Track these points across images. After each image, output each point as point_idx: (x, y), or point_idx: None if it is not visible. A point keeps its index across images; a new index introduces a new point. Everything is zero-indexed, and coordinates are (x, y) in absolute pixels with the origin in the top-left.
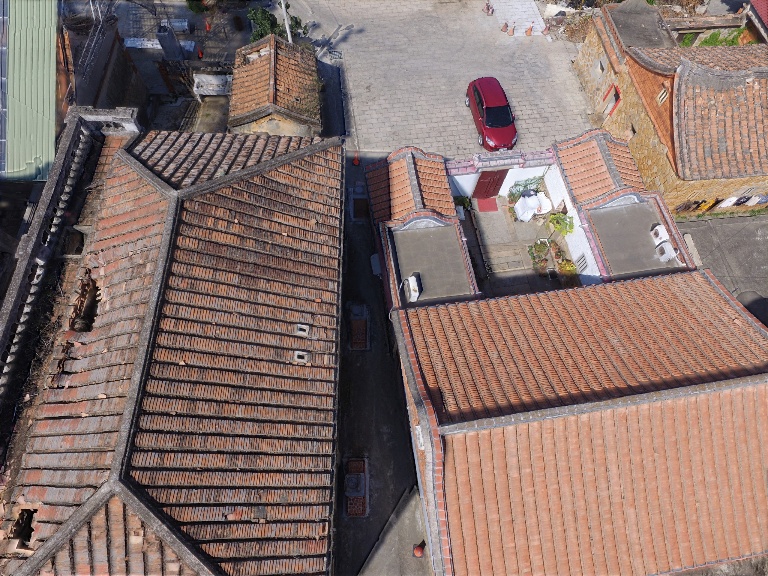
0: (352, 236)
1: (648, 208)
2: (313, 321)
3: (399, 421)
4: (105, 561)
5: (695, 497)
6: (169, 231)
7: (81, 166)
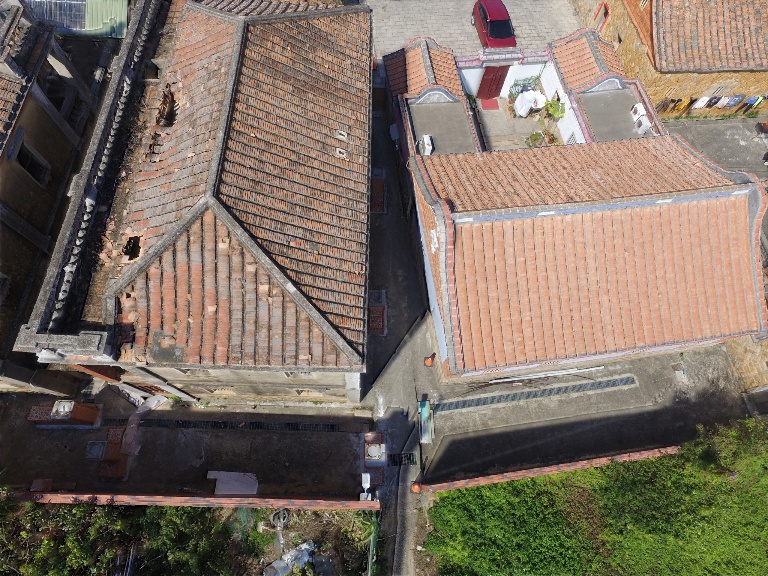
0: None
1: (629, 93)
2: (350, 131)
3: (412, 267)
4: (200, 261)
5: (658, 290)
6: (239, 42)
7: (154, 17)
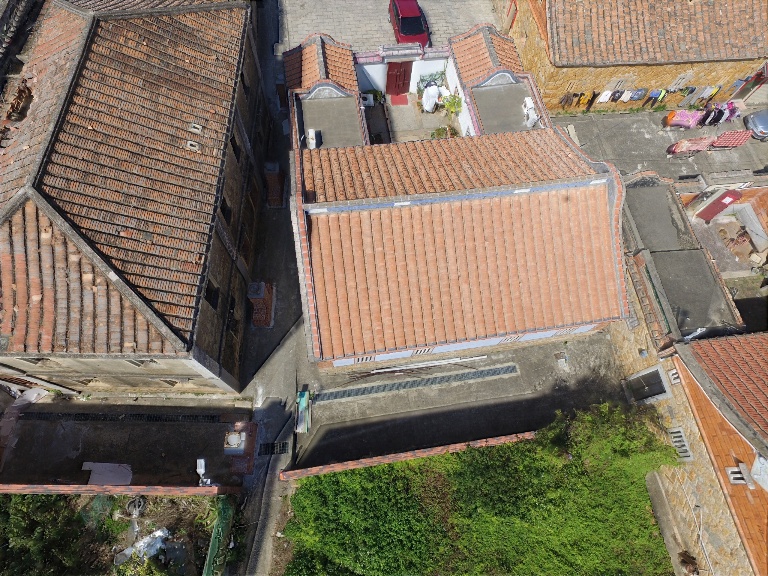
0: (278, 122)
1: (523, 88)
2: (206, 125)
3: None
4: (23, 251)
5: (519, 278)
6: (85, 37)
7: (25, 14)
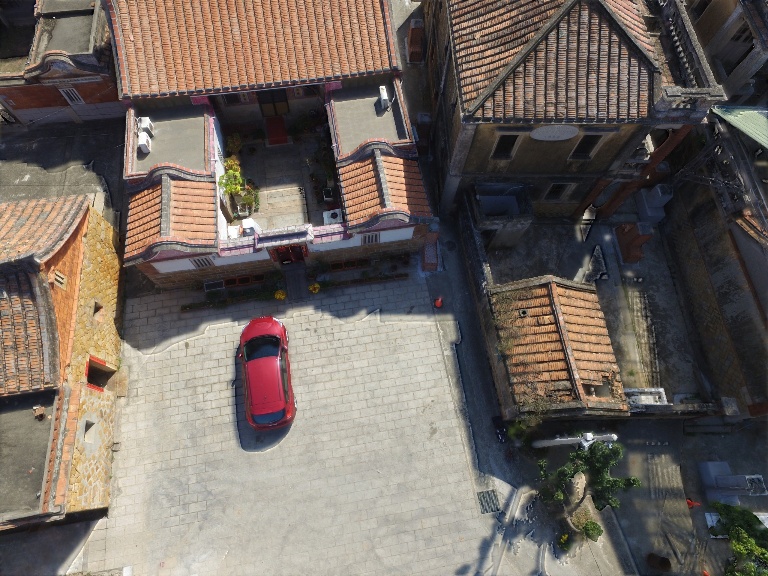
0: None
1: None
2: None
3: None
4: None
5: None
6: None
7: None
